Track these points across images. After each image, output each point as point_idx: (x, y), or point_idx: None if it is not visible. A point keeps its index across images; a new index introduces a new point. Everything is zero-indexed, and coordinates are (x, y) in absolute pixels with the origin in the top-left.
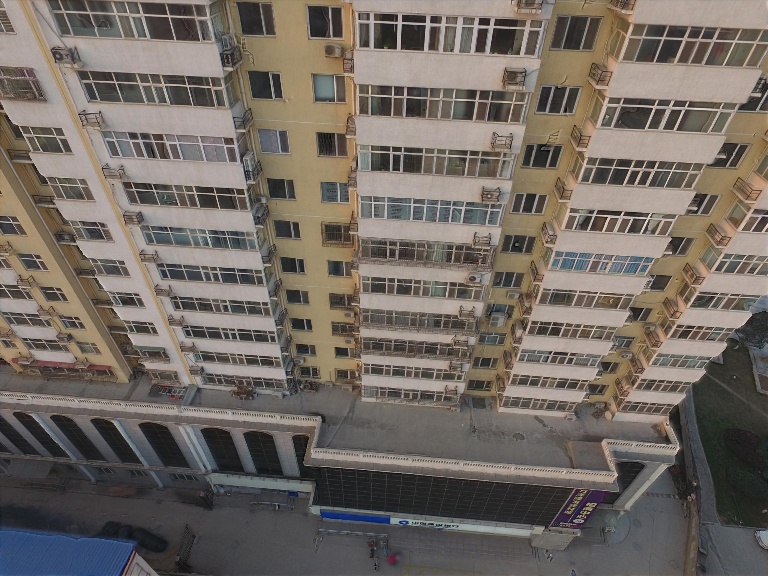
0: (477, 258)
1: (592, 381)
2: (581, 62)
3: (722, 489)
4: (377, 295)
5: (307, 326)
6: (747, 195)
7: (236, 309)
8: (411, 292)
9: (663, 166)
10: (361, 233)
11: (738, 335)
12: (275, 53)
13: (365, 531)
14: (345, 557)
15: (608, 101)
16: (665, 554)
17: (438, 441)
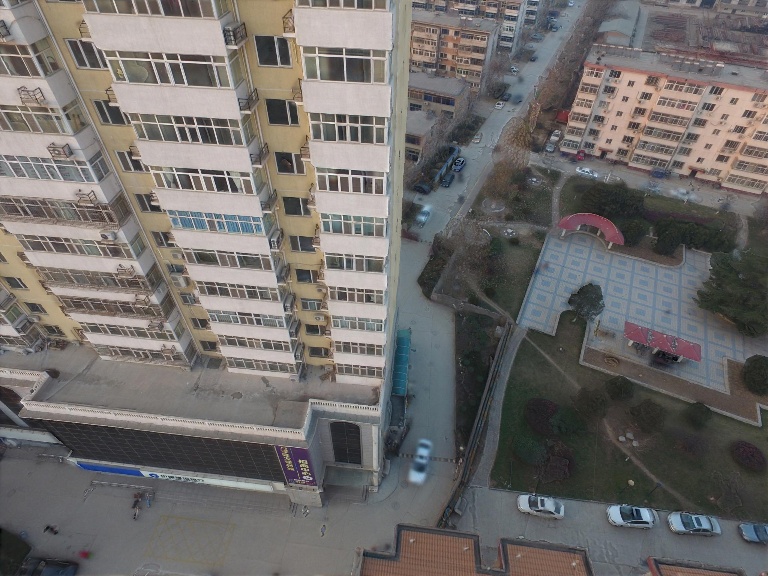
0: None
1: (310, 343)
2: None
3: (503, 455)
4: (39, 253)
5: (23, 285)
6: (301, 153)
7: None
8: (69, 250)
9: (202, 122)
10: None
11: (571, 307)
12: None
13: (133, 484)
14: (110, 507)
15: (105, 54)
16: (420, 513)
17: (156, 398)
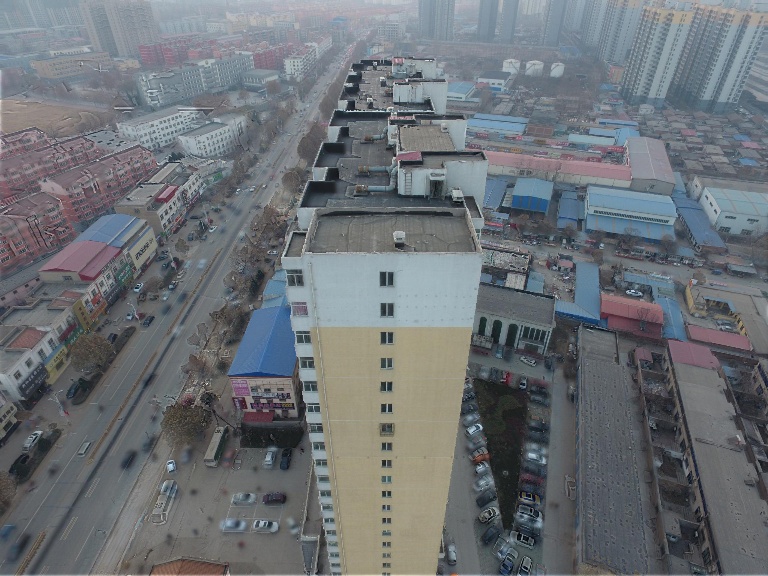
0: None
1: None
2: None
3: None
4: None
5: None
6: None
7: None
8: None
9: None
10: None
11: None
12: None
13: None
14: None
15: None
16: None
17: None
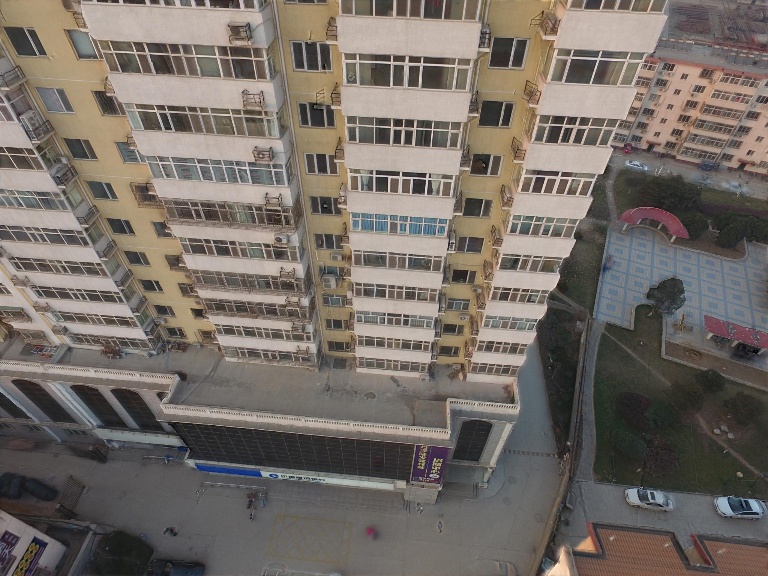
0: (278, 219)
1: (443, 343)
2: (320, 16)
3: (603, 449)
4: (199, 256)
5: (158, 287)
6: (515, 155)
7: (75, 270)
8: (231, 253)
9: (422, 125)
10: (160, 194)
11: None
12: (21, 8)
13: (245, 484)
14: (224, 507)
15: (344, 57)
16: (532, 508)
17: (290, 399)
